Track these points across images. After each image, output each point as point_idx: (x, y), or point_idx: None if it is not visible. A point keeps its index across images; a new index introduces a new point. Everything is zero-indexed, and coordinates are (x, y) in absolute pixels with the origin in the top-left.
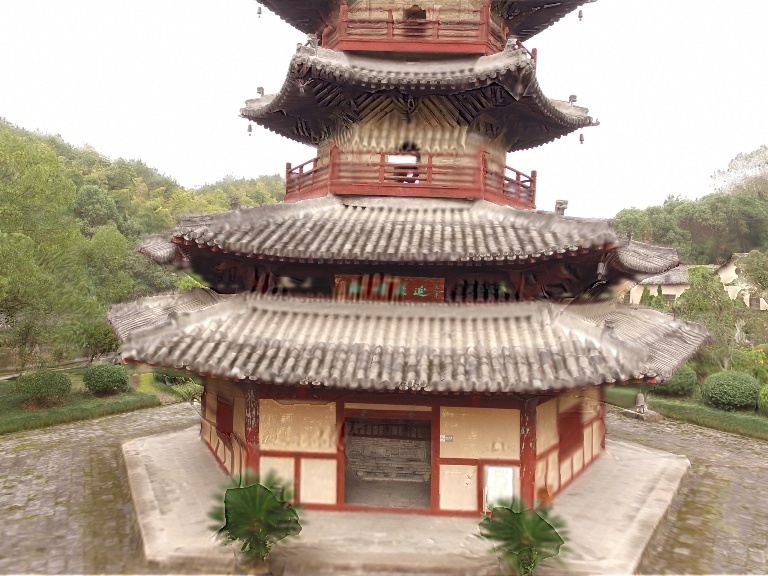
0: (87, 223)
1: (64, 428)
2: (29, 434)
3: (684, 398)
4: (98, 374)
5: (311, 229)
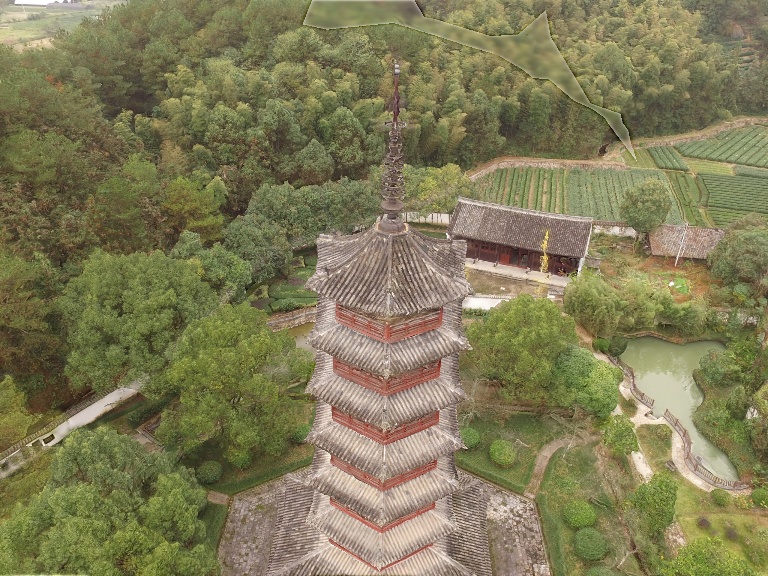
0: (338, 146)
1: (276, 486)
2: (263, 490)
3: (587, 563)
4: (297, 438)
5: (312, 572)
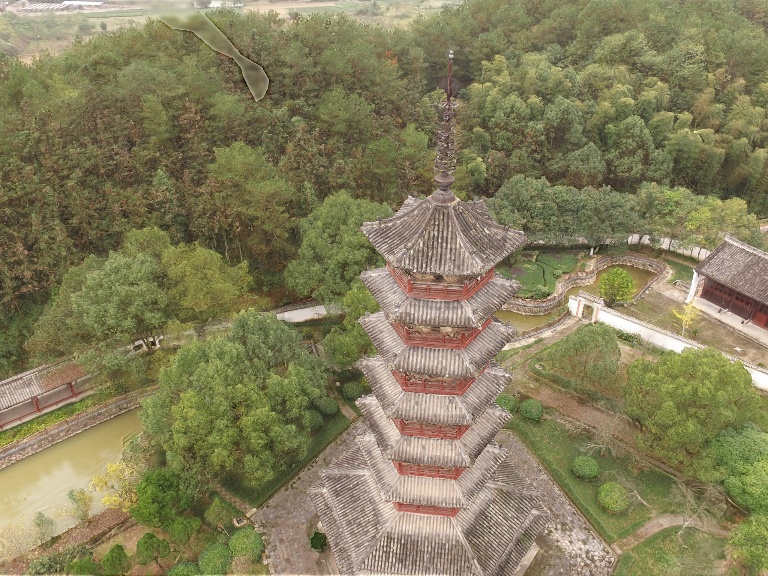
0: (617, 155)
1: None
2: None
3: None
4: None
5: None
